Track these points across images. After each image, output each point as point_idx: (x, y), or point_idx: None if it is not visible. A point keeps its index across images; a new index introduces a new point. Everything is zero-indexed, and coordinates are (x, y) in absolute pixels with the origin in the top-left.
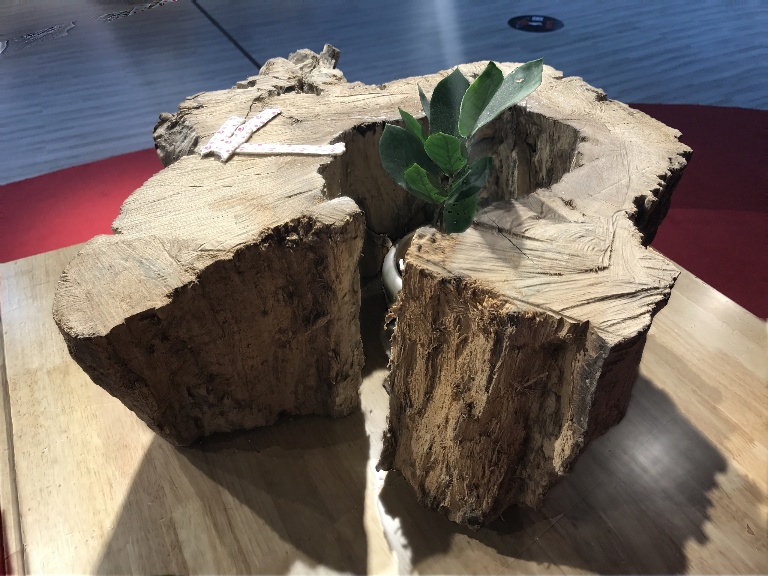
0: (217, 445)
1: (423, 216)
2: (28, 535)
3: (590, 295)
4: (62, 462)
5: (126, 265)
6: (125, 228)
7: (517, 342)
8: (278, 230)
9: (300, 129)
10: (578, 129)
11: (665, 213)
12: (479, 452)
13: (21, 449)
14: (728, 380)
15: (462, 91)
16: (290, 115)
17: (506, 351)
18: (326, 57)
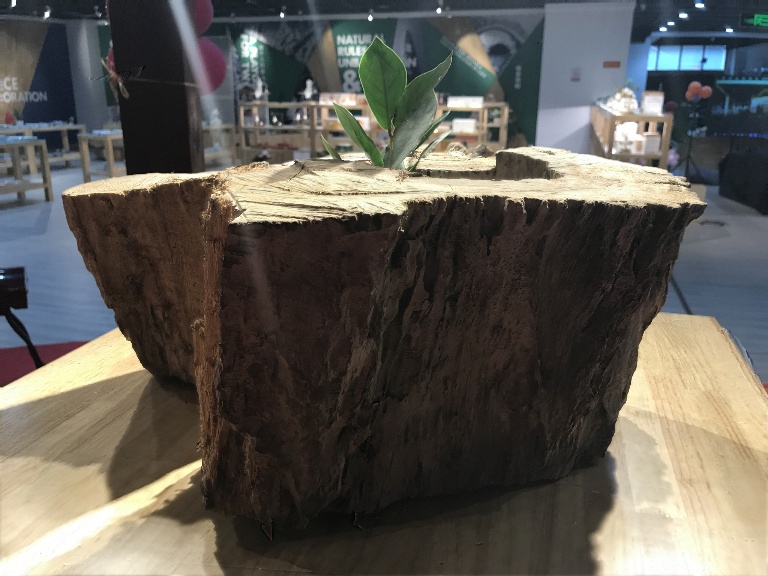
0: (173, 387)
1: None
2: (33, 374)
3: None
4: (98, 355)
5: (137, 180)
6: None
7: (214, 233)
8: None
9: None
10: (564, 176)
11: (609, 272)
12: (206, 384)
13: (94, 342)
14: None
15: (430, 108)
16: None
17: (206, 241)
18: (473, 152)
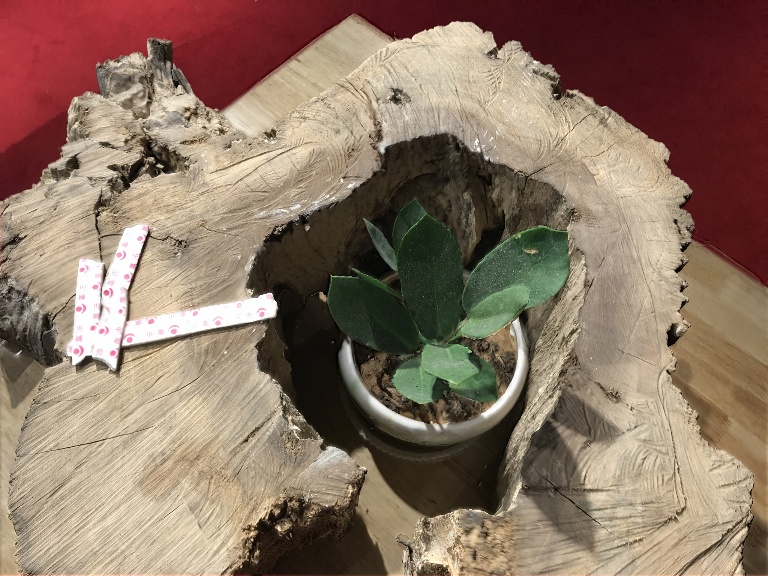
0: None
1: (356, 262)
2: None
3: (680, 563)
4: None
5: None
6: (42, 572)
7: None
8: (262, 523)
9: (192, 265)
10: (561, 192)
11: None
12: None
13: None
14: (693, 346)
15: None
16: (164, 233)
17: None
18: (156, 64)
